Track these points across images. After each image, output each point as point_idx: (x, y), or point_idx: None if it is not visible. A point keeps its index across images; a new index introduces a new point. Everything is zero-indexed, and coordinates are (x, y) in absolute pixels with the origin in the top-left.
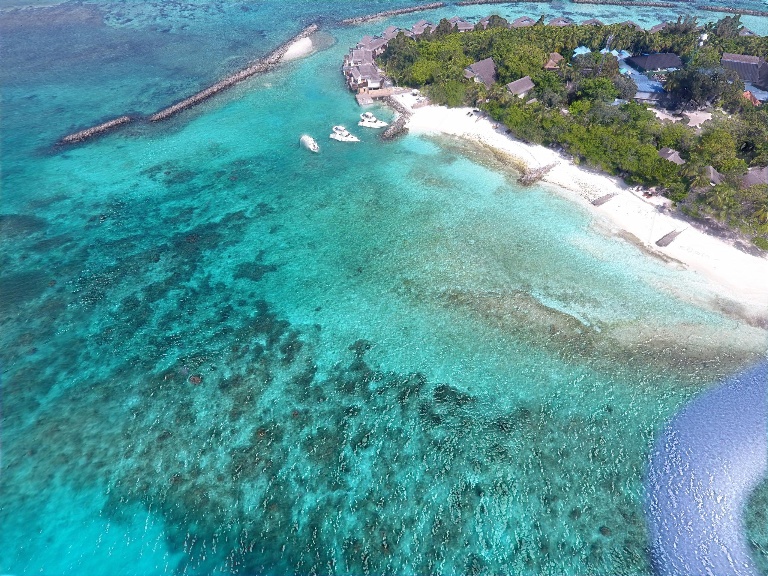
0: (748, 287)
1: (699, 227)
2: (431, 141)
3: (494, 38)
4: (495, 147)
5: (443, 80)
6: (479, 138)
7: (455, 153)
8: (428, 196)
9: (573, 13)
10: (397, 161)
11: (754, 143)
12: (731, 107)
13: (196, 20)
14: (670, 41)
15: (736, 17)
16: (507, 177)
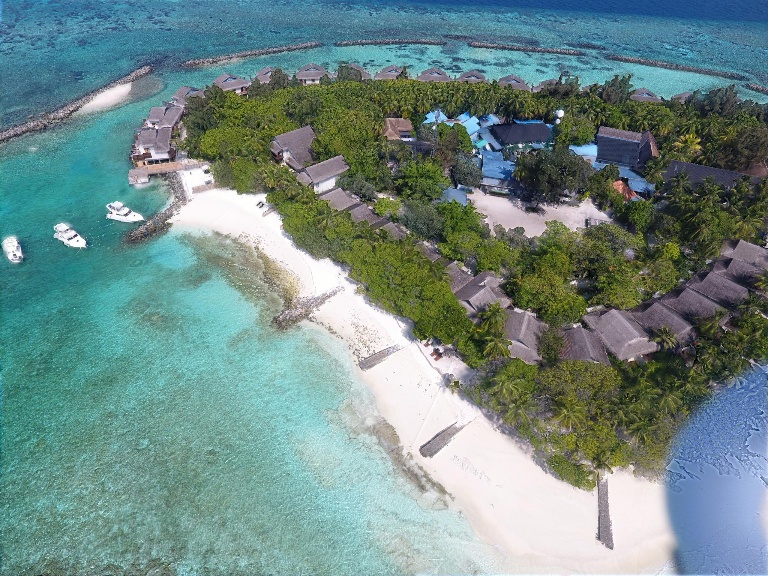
0: (530, 551)
1: (491, 419)
2: (192, 245)
3: (313, 101)
4: (272, 258)
5: (232, 157)
6: (257, 242)
7: (213, 267)
8: (131, 347)
9: (464, 59)
10: (125, 280)
11: (596, 273)
12: (599, 200)
13: (11, 55)
14: (544, 106)
15: (624, 79)
16: (262, 312)
